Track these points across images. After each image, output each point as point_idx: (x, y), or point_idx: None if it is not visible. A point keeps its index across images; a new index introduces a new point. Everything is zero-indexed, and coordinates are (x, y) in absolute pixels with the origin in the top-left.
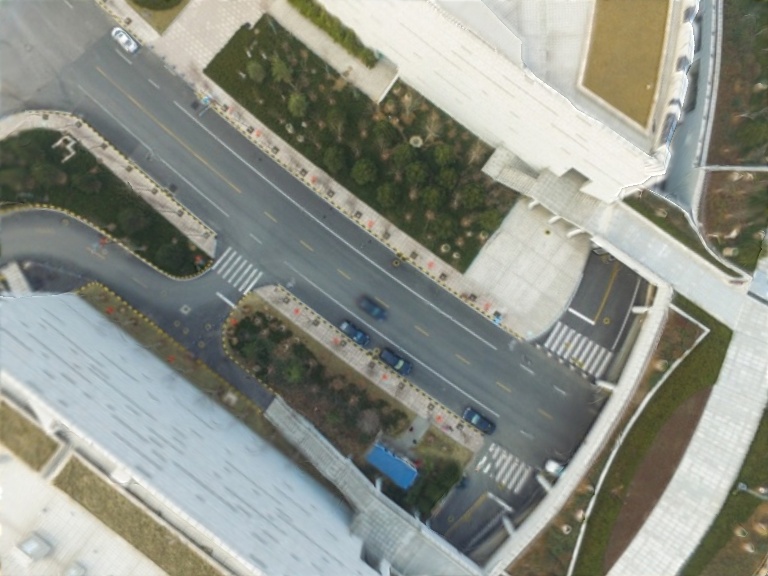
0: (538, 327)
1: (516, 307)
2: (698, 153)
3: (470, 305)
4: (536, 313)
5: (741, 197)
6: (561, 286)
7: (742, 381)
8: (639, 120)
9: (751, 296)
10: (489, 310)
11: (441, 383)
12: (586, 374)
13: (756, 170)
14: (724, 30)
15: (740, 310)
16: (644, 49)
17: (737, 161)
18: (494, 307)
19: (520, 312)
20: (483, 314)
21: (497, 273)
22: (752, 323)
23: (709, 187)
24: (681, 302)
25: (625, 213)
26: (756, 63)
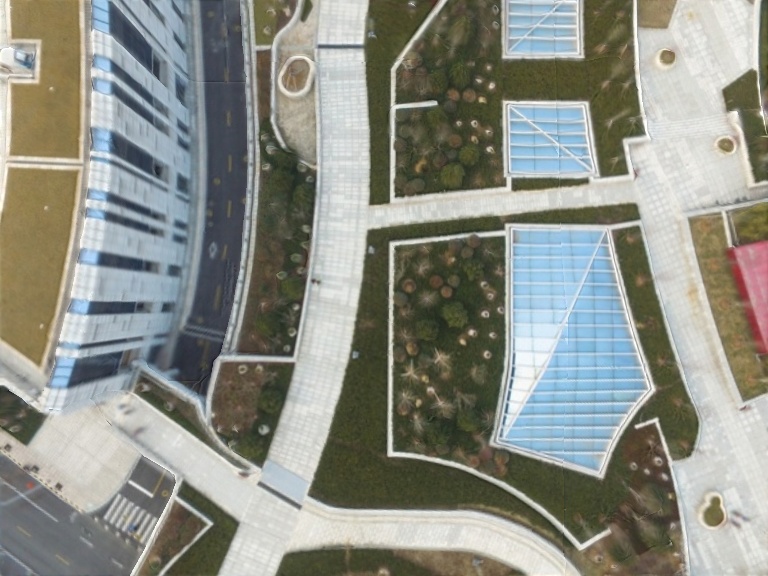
0: (98, 499)
1: (77, 479)
2: (228, 337)
3: (34, 476)
4: (97, 485)
5: (249, 389)
6: (122, 458)
7: (244, 574)
8: (34, 358)
9: (261, 487)
10: (51, 482)
11: (2, 555)
12: (142, 547)
13: (270, 360)
14: (258, 215)
15: (249, 501)
16: (42, 287)
17: (262, 347)
18: (56, 479)
19: (81, 484)
20: (46, 485)
21: (60, 445)
22: (260, 514)
23: (220, 379)
24: (187, 495)
25: (140, 403)
26: (281, 251)
